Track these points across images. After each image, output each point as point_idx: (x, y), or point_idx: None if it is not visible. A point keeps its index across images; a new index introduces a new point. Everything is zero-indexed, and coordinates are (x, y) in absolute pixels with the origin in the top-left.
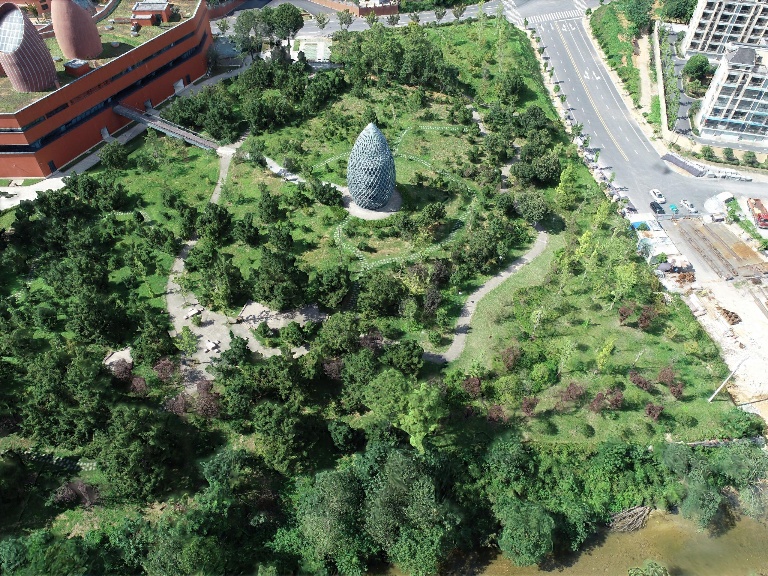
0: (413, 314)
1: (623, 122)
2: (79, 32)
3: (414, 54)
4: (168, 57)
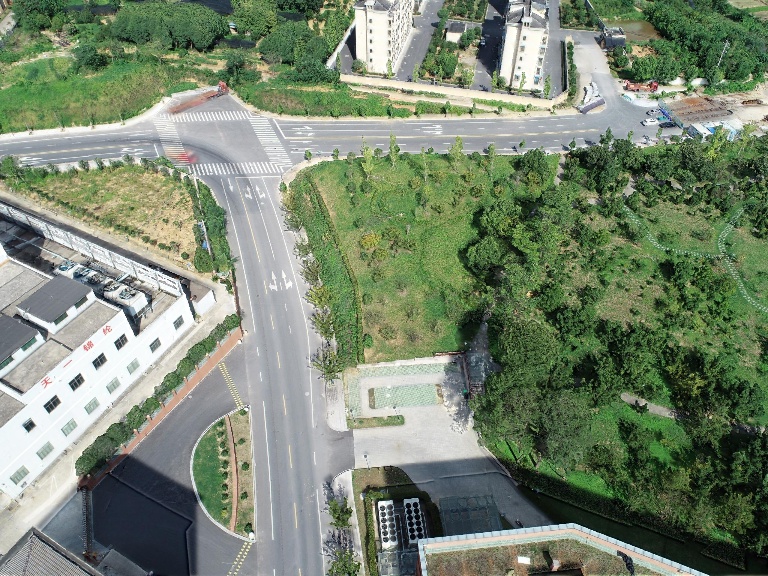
0: None
1: (529, 124)
2: None
3: None
4: None
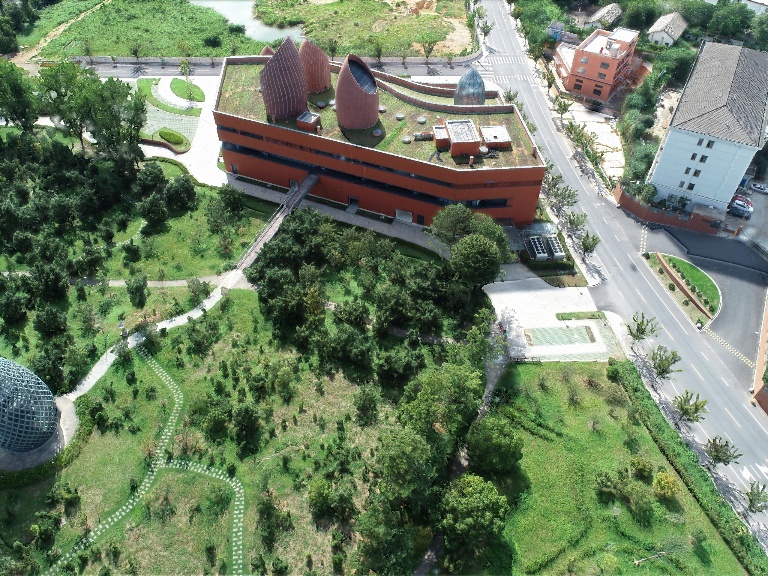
0: None
1: None
2: (340, 97)
3: (387, 456)
4: (400, 181)
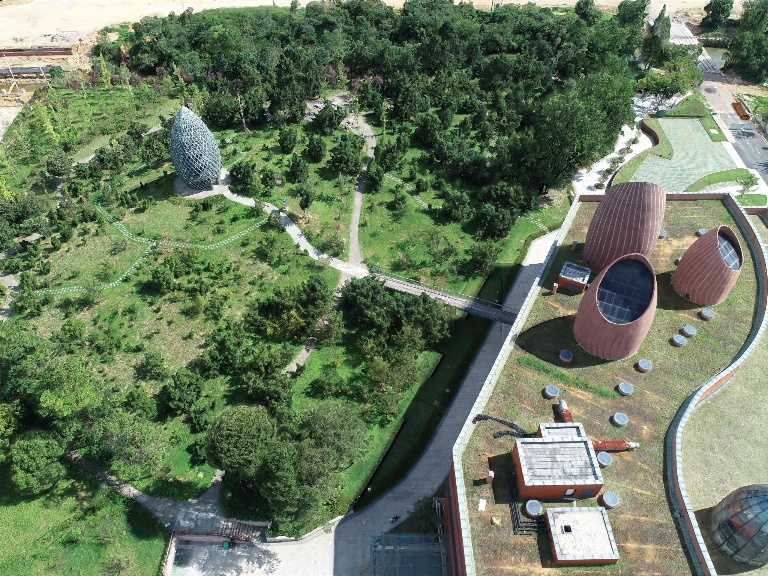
0: (205, 98)
1: None
2: None
3: None
4: None
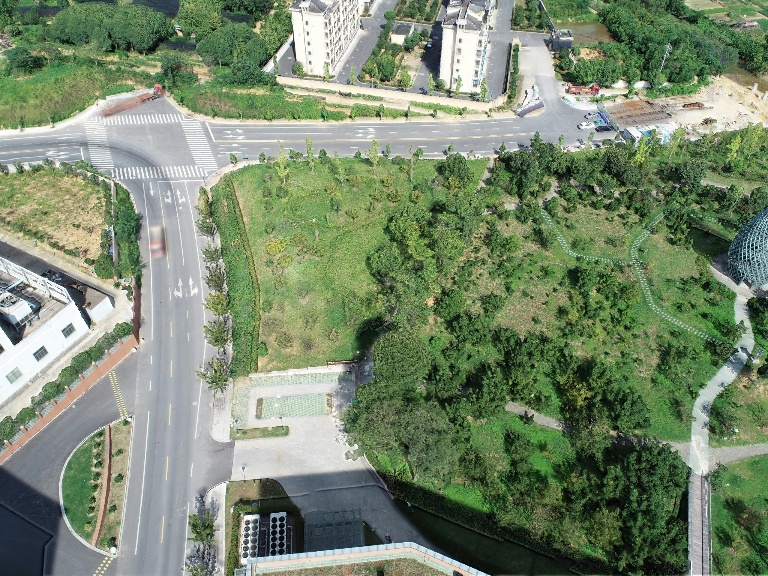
0: None
1: (464, 127)
2: None
3: None
4: None
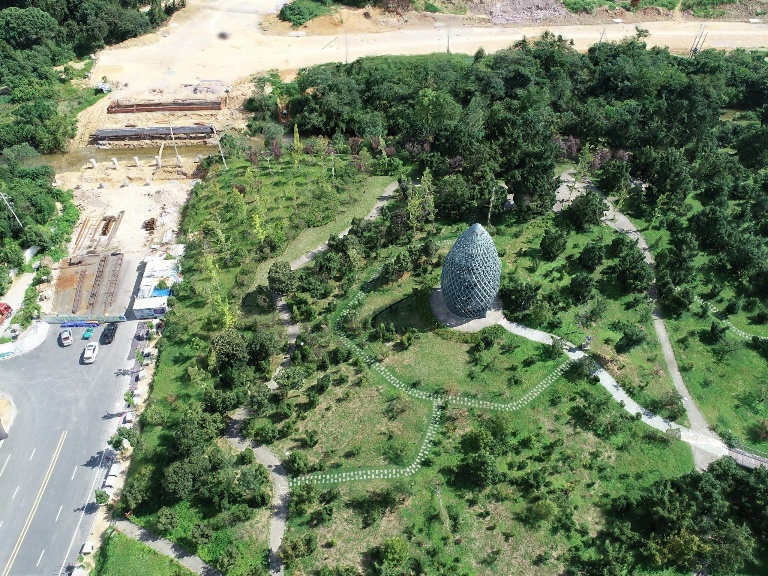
0: None
1: None
2: None
3: None
4: None
